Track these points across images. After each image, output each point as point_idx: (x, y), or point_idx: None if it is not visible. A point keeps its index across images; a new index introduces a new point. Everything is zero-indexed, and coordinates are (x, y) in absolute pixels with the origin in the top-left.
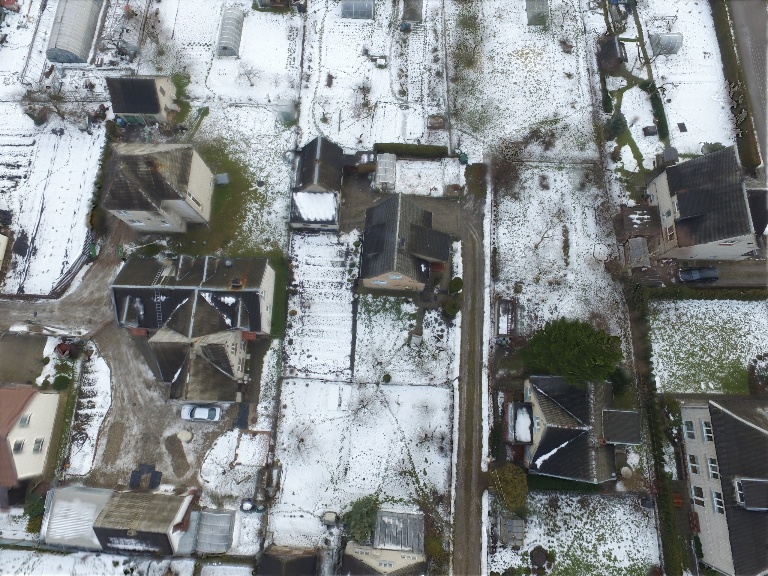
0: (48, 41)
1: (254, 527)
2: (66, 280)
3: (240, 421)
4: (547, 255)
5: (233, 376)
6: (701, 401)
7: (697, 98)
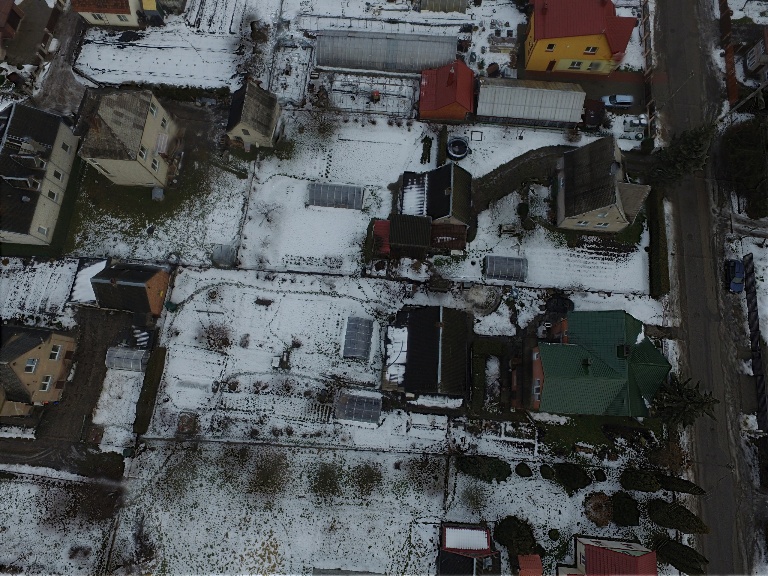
0: (333, 29)
1: None
2: None
3: None
4: None
5: None
6: None
7: None
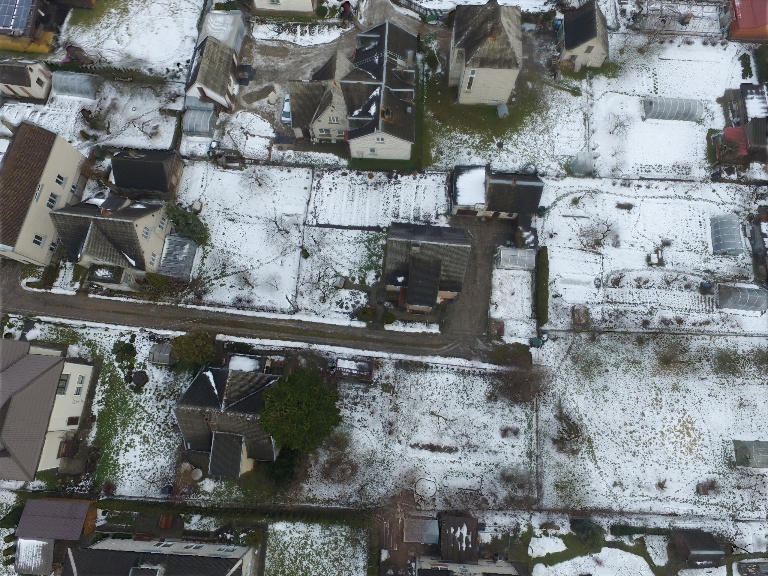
0: None
1: (199, 151)
2: (405, 2)
3: (281, 138)
4: (423, 424)
5: (312, 123)
6: (256, 574)
7: None
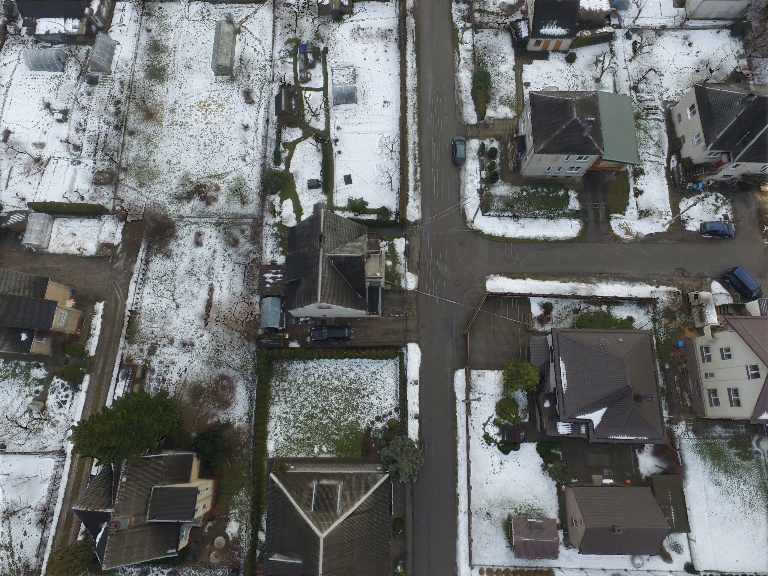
0: None
1: None
2: None
3: None
4: (187, 315)
5: None
6: (311, 465)
7: (368, 149)
